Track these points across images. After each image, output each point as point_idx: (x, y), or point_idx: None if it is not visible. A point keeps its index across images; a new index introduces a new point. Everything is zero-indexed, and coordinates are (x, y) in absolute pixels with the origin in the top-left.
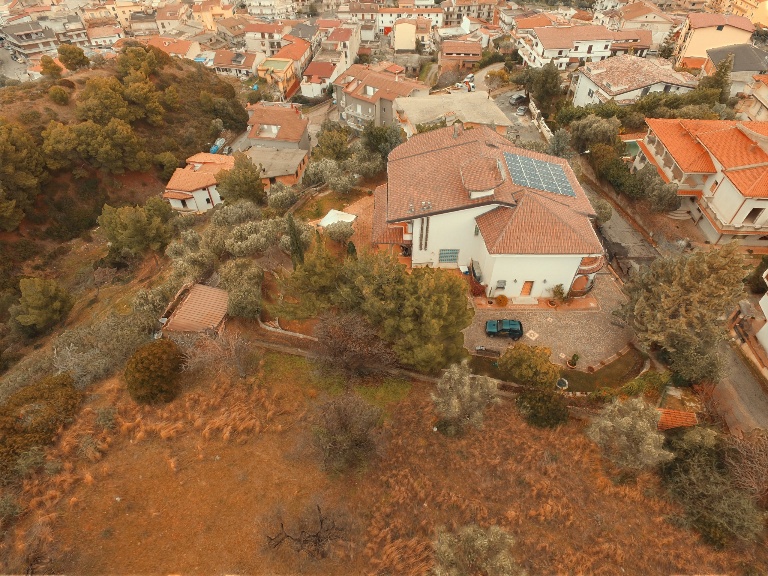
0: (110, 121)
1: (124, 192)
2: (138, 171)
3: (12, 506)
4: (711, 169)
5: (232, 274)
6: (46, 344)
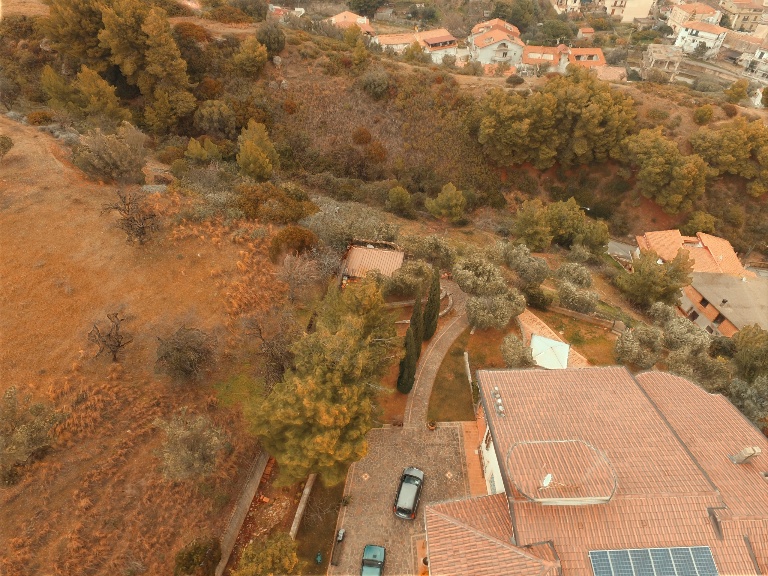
0: (693, 155)
1: (634, 212)
2: (662, 207)
3: (204, 215)
4: None
5: (406, 267)
6: (427, 226)
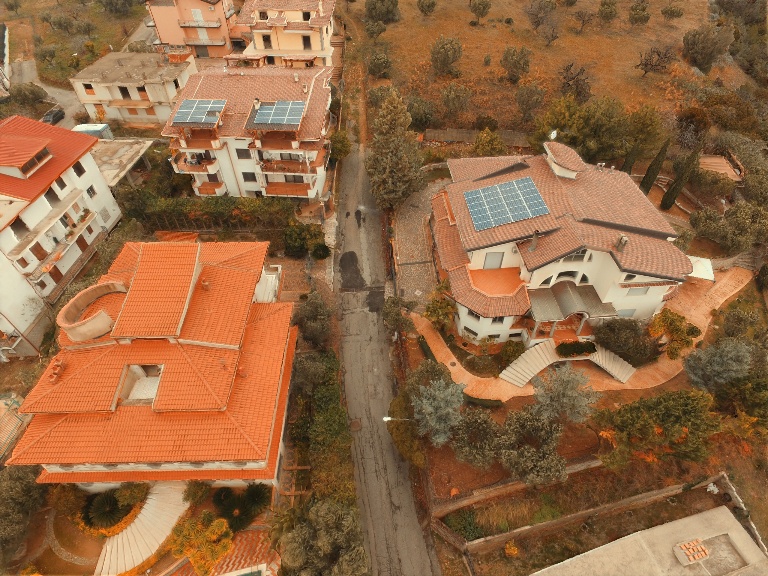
0: None
1: None
2: None
3: None
4: (255, 306)
5: None
6: None
